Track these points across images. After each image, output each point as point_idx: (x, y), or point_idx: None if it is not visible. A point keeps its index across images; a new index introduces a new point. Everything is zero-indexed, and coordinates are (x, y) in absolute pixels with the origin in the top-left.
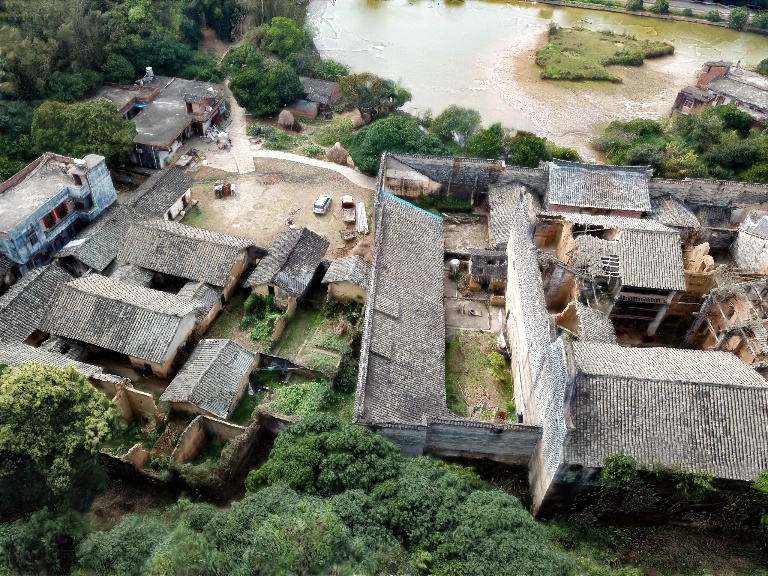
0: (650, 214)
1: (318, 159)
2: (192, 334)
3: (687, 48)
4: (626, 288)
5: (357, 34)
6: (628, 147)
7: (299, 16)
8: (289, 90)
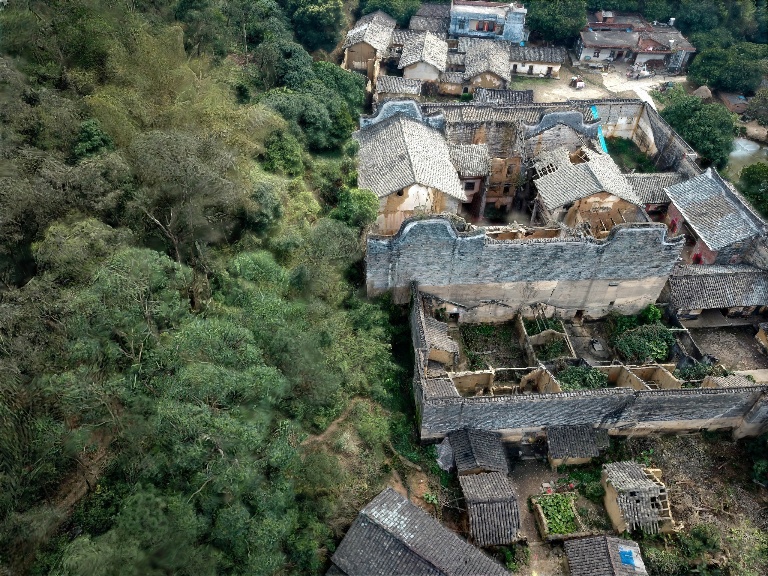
0: (724, 265)
1: None
2: (431, 83)
3: None
4: None
5: None
6: None
7: None
8: (729, 77)
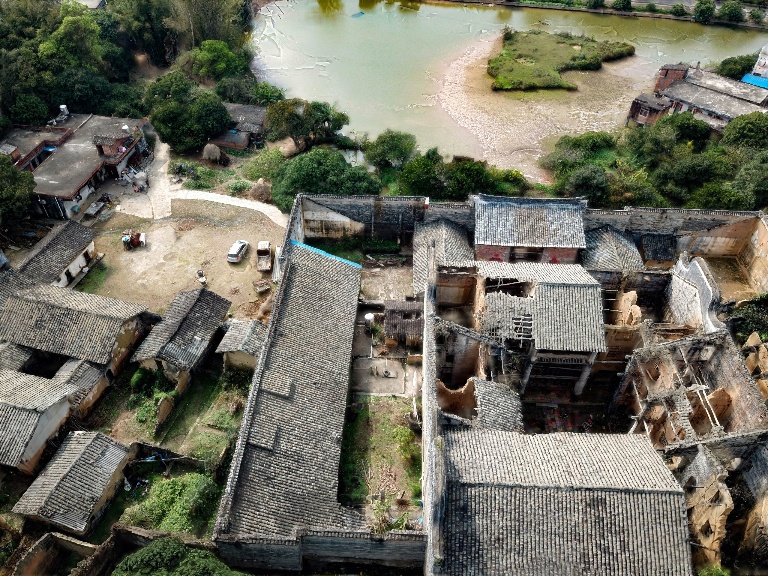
0: (587, 249)
1: (241, 197)
2: (66, 422)
3: (648, 48)
4: (542, 349)
5: (301, 50)
6: (577, 164)
7: (237, 36)
8: (214, 122)
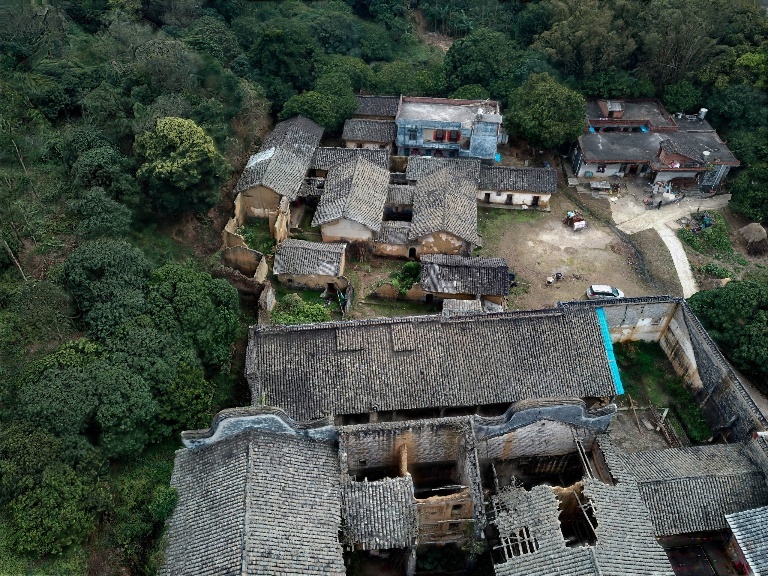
0: None
1: None
2: (361, 242)
3: None
4: None
5: None
6: None
7: None
8: None
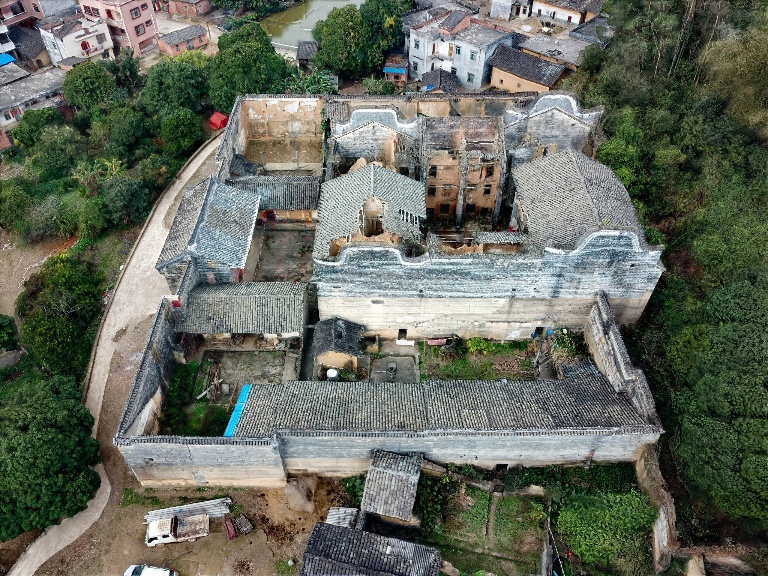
0: None
1: None
2: None
3: None
4: None
5: None
6: None
7: None
8: None
